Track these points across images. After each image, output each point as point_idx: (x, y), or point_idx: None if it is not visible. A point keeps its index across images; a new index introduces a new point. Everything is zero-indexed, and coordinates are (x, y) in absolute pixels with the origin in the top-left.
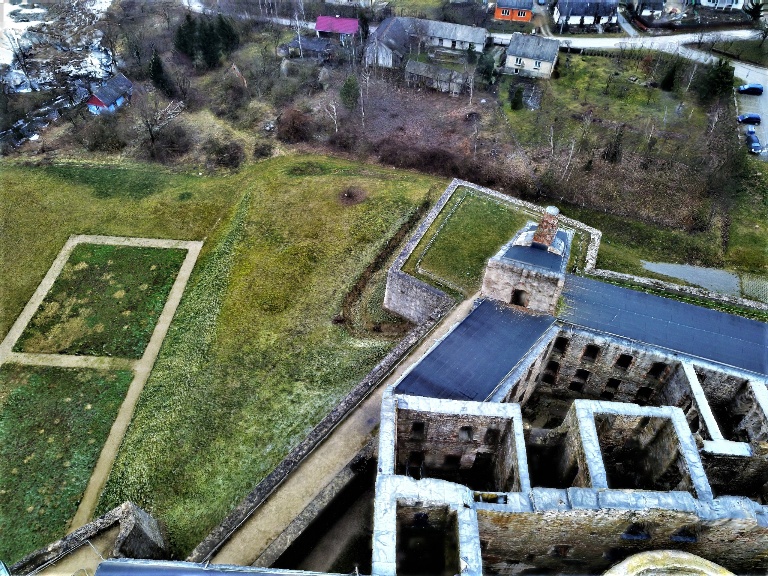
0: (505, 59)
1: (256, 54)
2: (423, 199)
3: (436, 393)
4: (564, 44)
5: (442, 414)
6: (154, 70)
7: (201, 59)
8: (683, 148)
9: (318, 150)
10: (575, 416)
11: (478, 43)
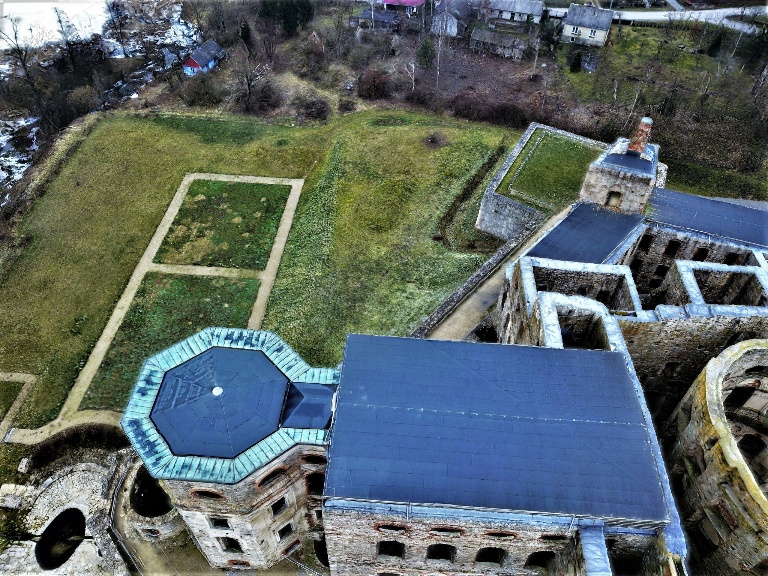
0: (561, 29)
1: (328, 25)
2: (498, 145)
3: None
4: (616, 16)
5: (567, 271)
6: (243, 36)
7: (281, 28)
8: (731, 104)
9: (397, 106)
10: (676, 272)
11: (536, 15)
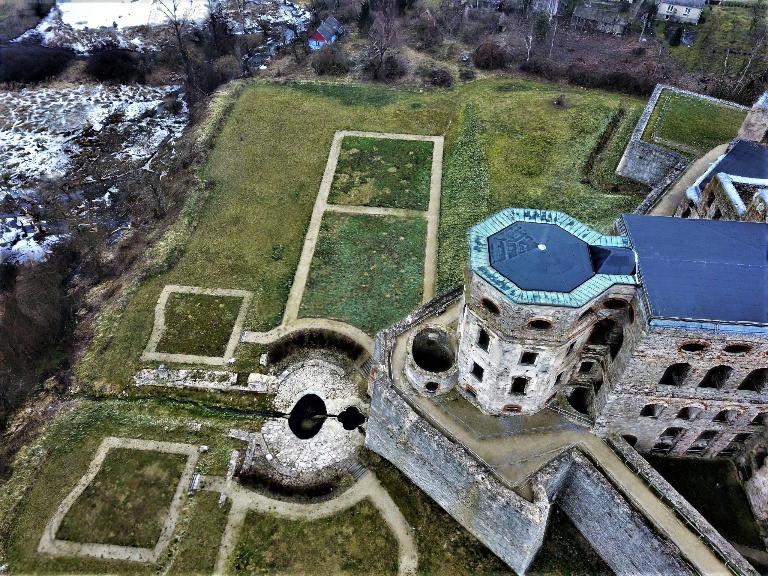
0: (655, 8)
1: (431, 5)
2: (618, 107)
3: None
4: None
5: (756, 186)
6: (363, 12)
7: (391, 7)
8: None
9: (513, 75)
10: None
11: None
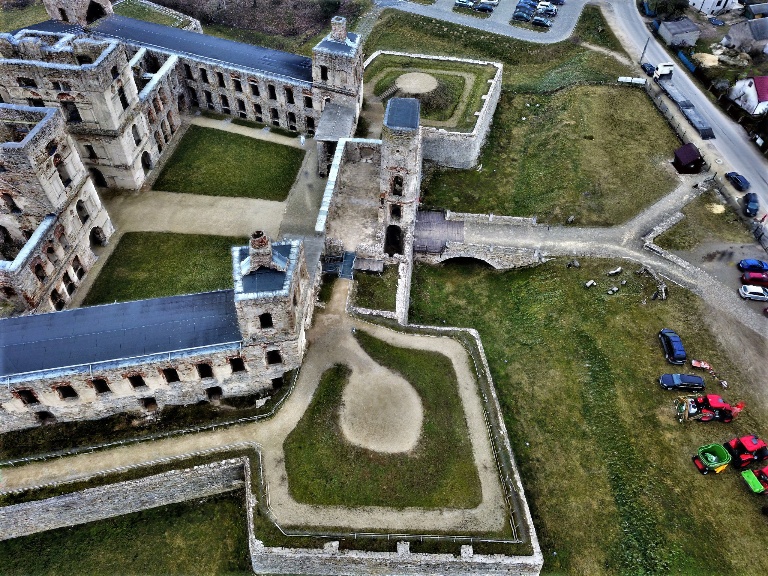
0: None
1: None
2: None
3: None
4: None
5: None
6: None
7: None
8: None
9: None
10: None
11: None
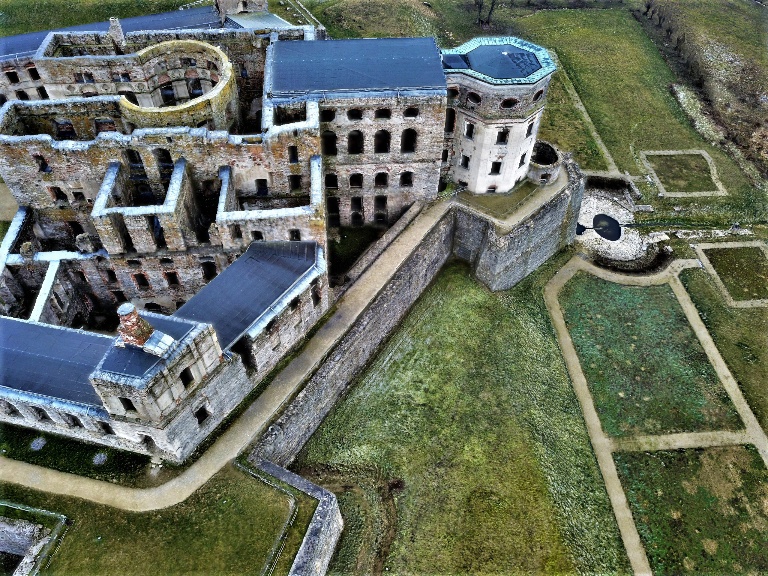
0: None
1: None
2: None
3: (280, 260)
4: None
5: None
6: None
7: None
8: None
9: None
10: None
11: None
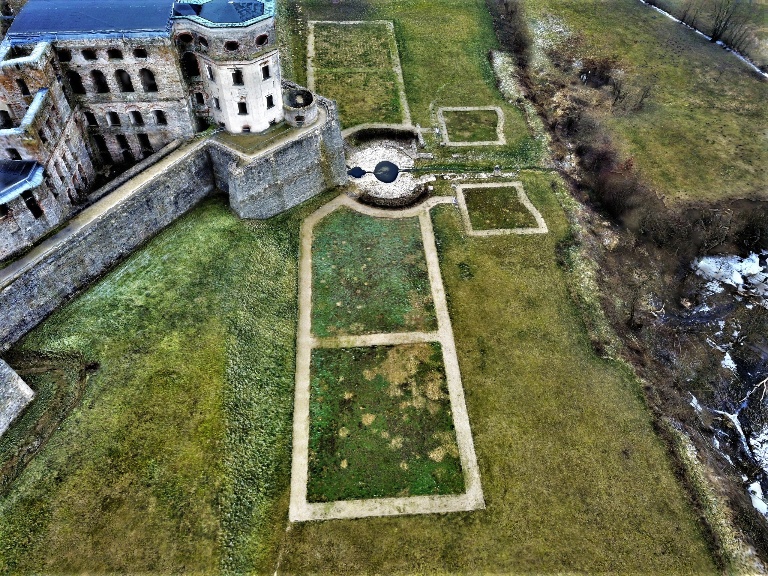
0: None
1: None
2: None
3: None
4: None
5: None
6: None
7: None
8: None
9: None
10: None
11: None
